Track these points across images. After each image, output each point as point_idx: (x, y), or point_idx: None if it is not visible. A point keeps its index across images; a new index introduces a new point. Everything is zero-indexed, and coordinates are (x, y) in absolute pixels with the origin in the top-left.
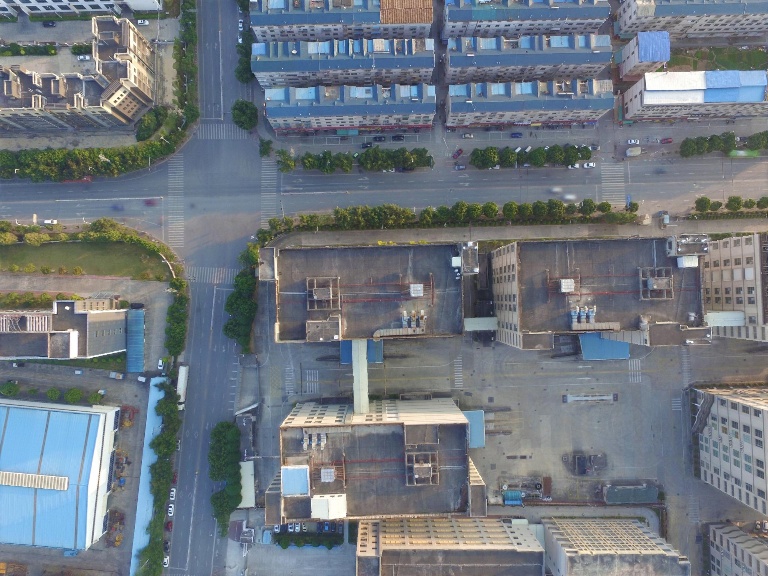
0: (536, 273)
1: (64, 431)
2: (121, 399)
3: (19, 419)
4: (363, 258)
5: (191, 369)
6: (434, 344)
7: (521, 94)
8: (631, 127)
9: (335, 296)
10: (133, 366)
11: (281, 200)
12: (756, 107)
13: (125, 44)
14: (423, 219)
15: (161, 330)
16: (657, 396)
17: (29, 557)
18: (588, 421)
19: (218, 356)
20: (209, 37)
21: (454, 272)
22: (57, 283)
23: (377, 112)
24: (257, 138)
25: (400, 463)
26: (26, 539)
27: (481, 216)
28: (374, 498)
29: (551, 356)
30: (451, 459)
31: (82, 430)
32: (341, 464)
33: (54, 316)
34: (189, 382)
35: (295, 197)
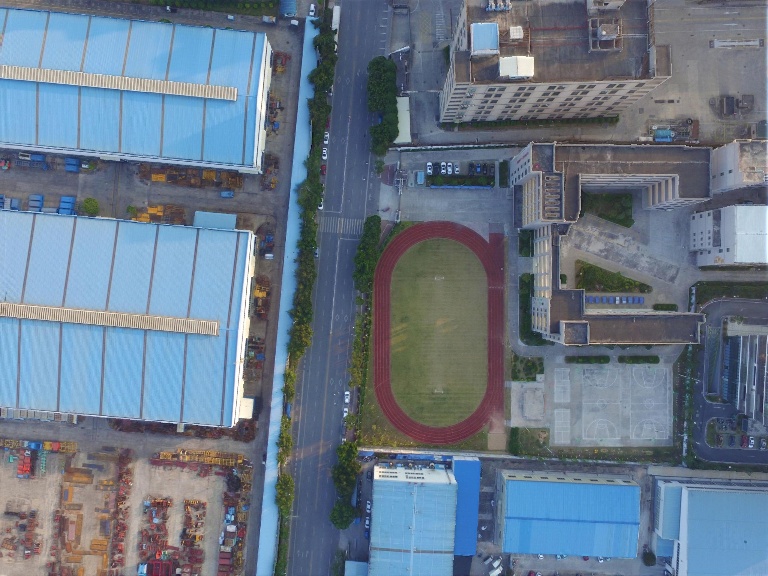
0: None
1: (230, 47)
2: (273, 46)
3: (185, 36)
4: None
5: (342, 16)
6: None
7: None
8: None
9: None
10: (287, 6)
11: None
12: None
13: None
14: None
15: None
16: None
17: (185, 200)
18: (735, 66)
19: (368, 3)
20: None
21: None
22: None
23: None
24: None
25: (583, 31)
26: (195, 154)
27: None
28: (557, 66)
29: (698, 2)
30: (633, 28)
31: (248, 47)
32: (526, 29)
33: None
34: (340, 29)
35: None
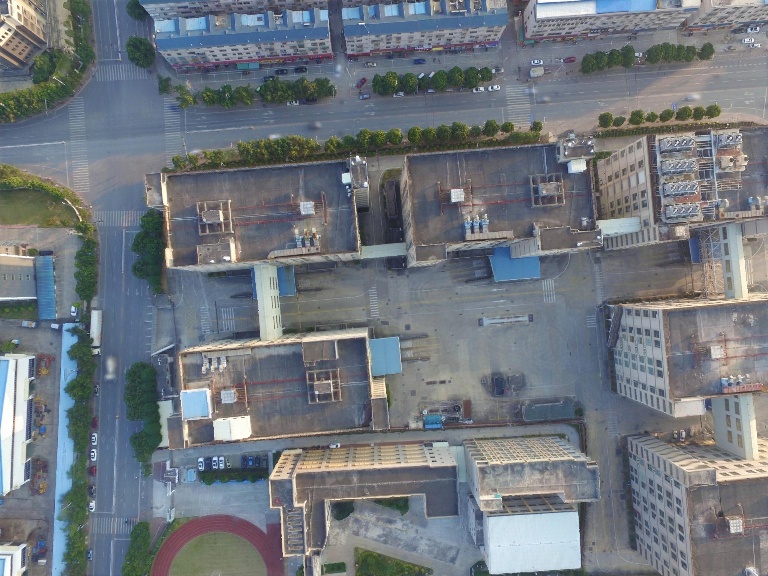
0: (428, 186)
1: None
2: (36, 348)
3: None
4: (254, 180)
5: (105, 314)
6: (348, 275)
7: (415, 14)
8: (534, 48)
9: (227, 219)
10: (44, 313)
11: (185, 139)
12: (652, 17)
13: None
14: (327, 148)
15: (72, 277)
16: (572, 314)
17: None
18: (505, 343)
19: (132, 299)
20: None
21: (346, 189)
22: None
23: (270, 39)
24: None
25: (302, 382)
26: None
27: (388, 145)
28: (278, 418)
29: (465, 281)
30: (353, 375)
31: None
32: (242, 386)
33: None
34: (104, 327)
35: (200, 135)
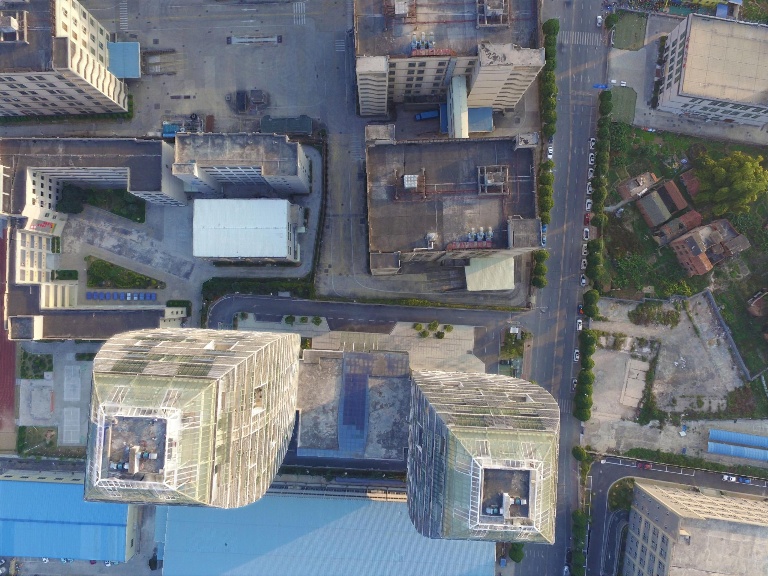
0: None
1: None
2: None
3: None
4: None
5: None
6: None
7: None
8: None
9: None
10: None
11: None
12: None
13: None
14: None
15: None
16: (321, 38)
17: None
18: (252, 62)
19: None
20: None
21: None
22: None
23: None
24: None
25: None
26: None
27: None
28: None
29: None
30: (42, 20)
31: None
32: None
33: None
34: None
35: None
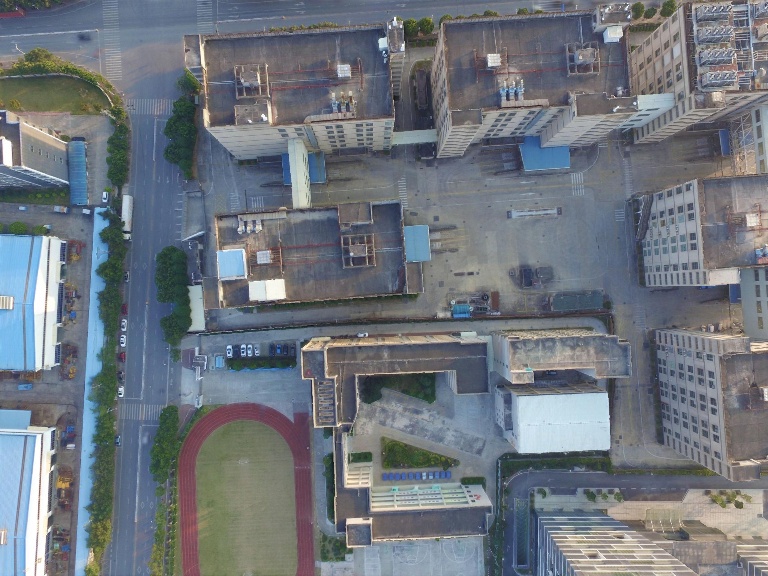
0: (464, 54)
1: (7, 253)
2: (67, 234)
3: None
4: (290, 46)
5: (136, 201)
6: (377, 166)
7: None
8: None
9: (264, 83)
10: (76, 197)
11: None
12: None
13: None
14: None
15: (104, 164)
16: (600, 208)
17: None
18: (533, 235)
19: (162, 187)
20: None
21: (382, 56)
22: None
23: None
24: None
25: (336, 247)
26: None
27: (419, 36)
28: (312, 283)
29: (494, 173)
30: (387, 241)
31: (25, 252)
32: (277, 249)
33: None
34: (135, 214)
35: (232, 25)
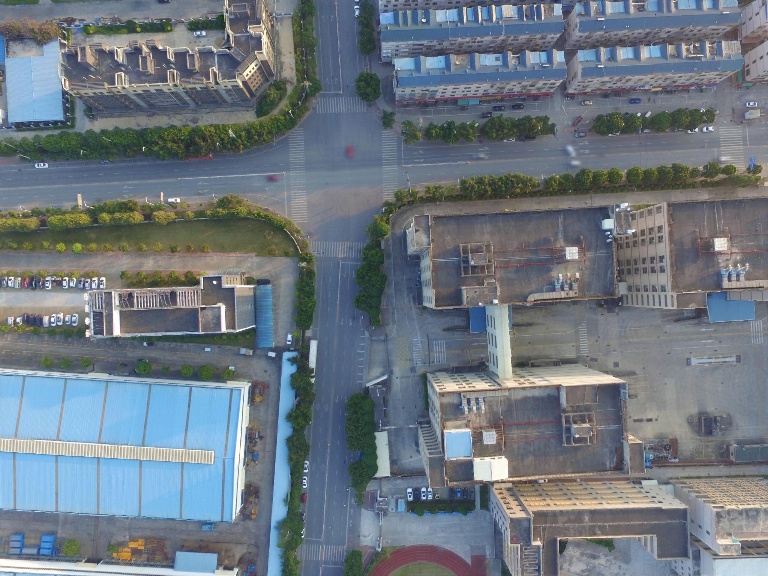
0: (685, 233)
1: (207, 406)
2: (251, 375)
3: (161, 395)
4: (514, 223)
5: (319, 343)
6: (559, 311)
7: (650, 57)
8: (749, 90)
9: (489, 262)
10: (264, 341)
11: (403, 172)
12: None
13: (259, 16)
14: (550, 187)
15: (287, 305)
16: None
17: (166, 532)
18: (712, 383)
19: (345, 329)
20: (325, 9)
21: (605, 235)
22: (182, 261)
23: (508, 79)
24: (376, 111)
25: (556, 424)
26: (173, 513)
27: None
28: (532, 459)
29: (674, 320)
30: (606, 419)
31: (224, 404)
32: (500, 427)
33: (201, 291)
34: (317, 356)
35: (416, 169)
